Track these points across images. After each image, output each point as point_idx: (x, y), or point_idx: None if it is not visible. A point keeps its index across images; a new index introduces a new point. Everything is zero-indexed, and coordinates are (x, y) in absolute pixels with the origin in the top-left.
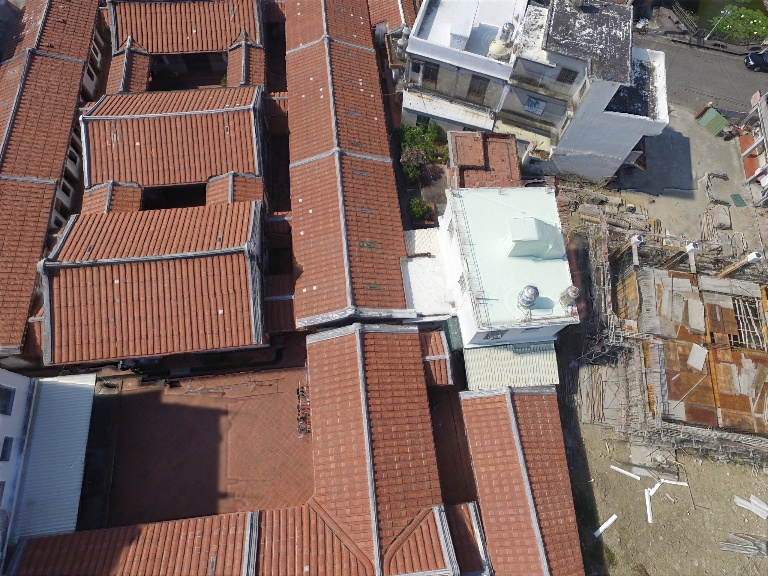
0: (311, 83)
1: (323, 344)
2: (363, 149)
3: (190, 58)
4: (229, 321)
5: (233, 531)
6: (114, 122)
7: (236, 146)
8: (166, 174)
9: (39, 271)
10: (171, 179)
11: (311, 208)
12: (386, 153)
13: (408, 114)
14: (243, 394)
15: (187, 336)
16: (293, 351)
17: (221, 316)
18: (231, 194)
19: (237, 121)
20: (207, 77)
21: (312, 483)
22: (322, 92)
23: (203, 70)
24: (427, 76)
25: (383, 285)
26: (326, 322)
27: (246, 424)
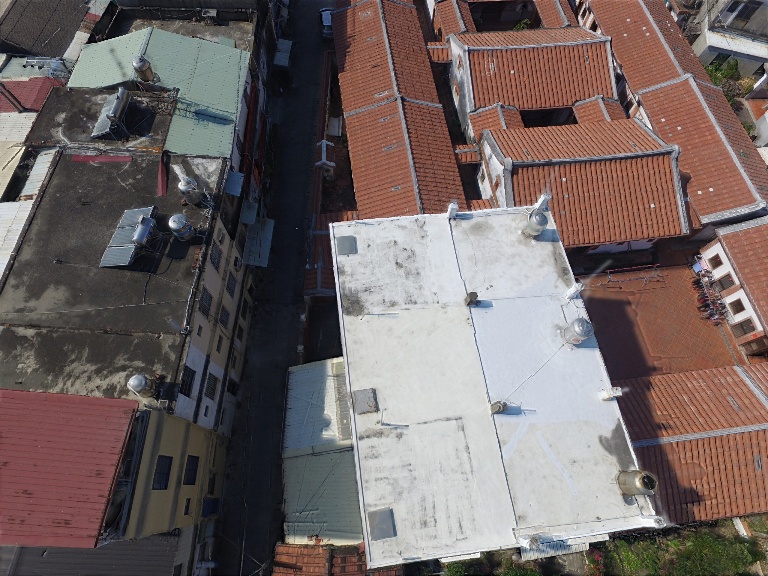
0: (630, 23)
1: (739, 234)
2: (697, 78)
3: (490, 7)
4: (660, 214)
5: (731, 379)
6: (491, 52)
7: (595, 74)
8: (538, 99)
9: (507, 168)
10: (542, 103)
11: (679, 125)
12: (711, 83)
13: (708, 53)
14: (637, 288)
15: (626, 227)
16: (666, 253)
17: (653, 209)
18: (608, 114)
19: (595, 52)
20: (497, 26)
21: (725, 359)
22: (646, 30)
23: (492, 20)
24: (740, 15)
25: (767, 187)
26: (727, 218)
27: (649, 312)
